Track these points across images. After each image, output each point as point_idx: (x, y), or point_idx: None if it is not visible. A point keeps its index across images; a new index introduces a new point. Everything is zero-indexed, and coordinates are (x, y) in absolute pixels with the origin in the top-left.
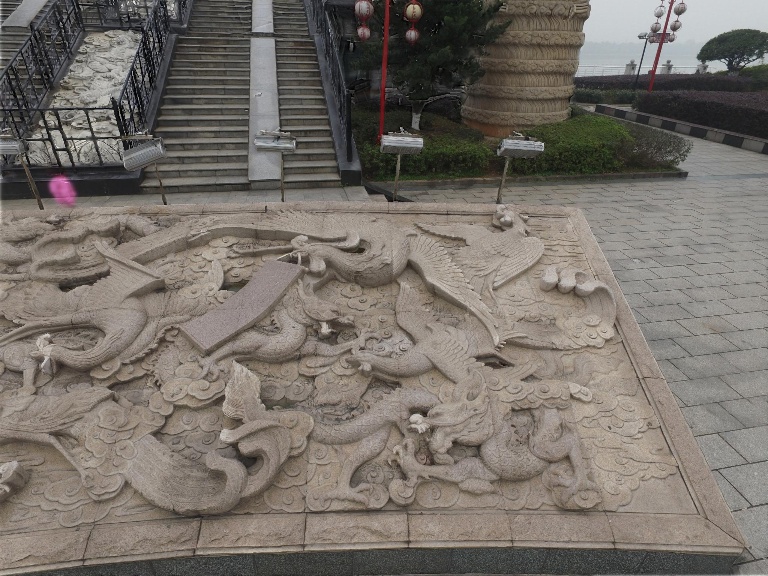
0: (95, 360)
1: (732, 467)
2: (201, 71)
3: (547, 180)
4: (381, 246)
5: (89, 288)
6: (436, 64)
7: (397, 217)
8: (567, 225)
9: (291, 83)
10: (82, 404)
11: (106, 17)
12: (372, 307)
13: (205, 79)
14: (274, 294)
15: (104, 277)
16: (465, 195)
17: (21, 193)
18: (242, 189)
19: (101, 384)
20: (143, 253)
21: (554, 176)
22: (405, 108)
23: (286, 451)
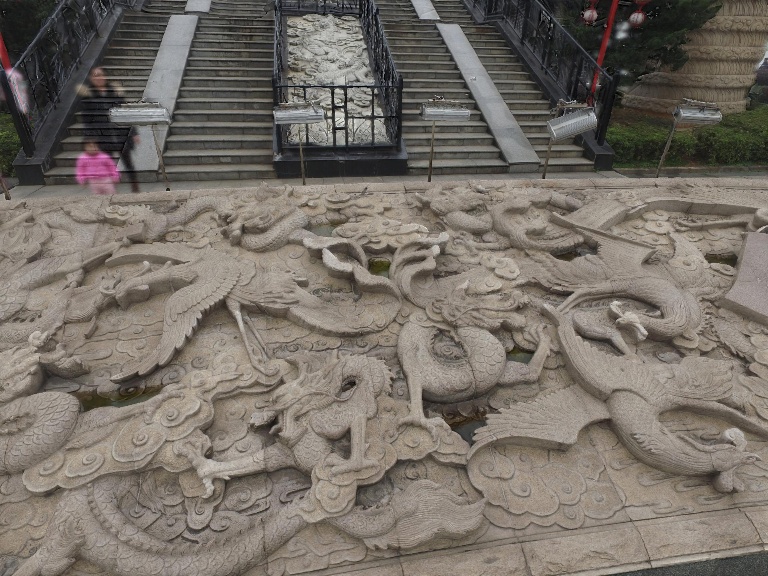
0: (683, 329)
1: None
2: (405, 55)
3: (750, 170)
4: None
5: (596, 257)
6: (653, 49)
7: None
8: None
9: (493, 68)
10: (720, 373)
11: (304, 1)
12: None
13: (413, 63)
14: None
15: (578, 248)
16: None
17: (297, 172)
18: (500, 172)
19: (692, 354)
20: (602, 224)
21: (756, 166)
22: None
23: None
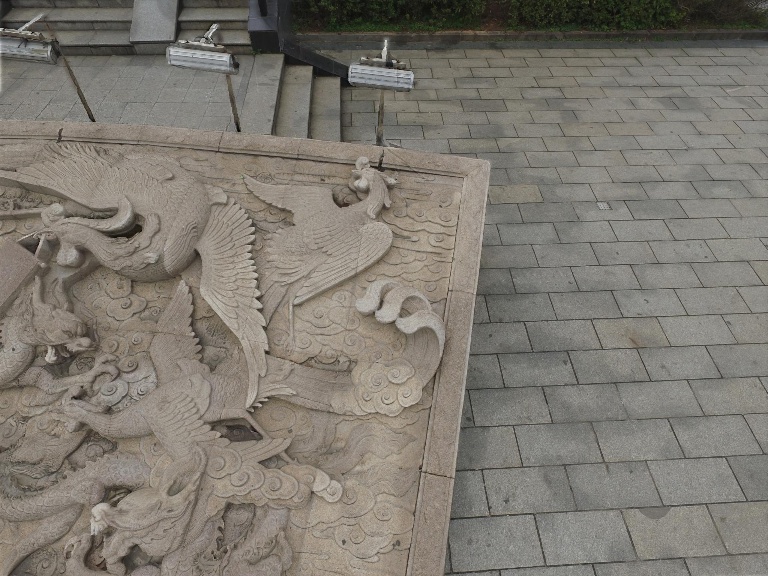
0: None
1: (521, 569)
2: None
3: (565, 38)
4: (152, 232)
5: None
6: None
7: (227, 160)
8: (456, 193)
9: None
10: None
11: None
12: (135, 316)
13: None
14: (2, 296)
15: None
16: (437, 62)
17: None
18: (125, 53)
19: None
20: None
21: (577, 32)
22: None
23: None
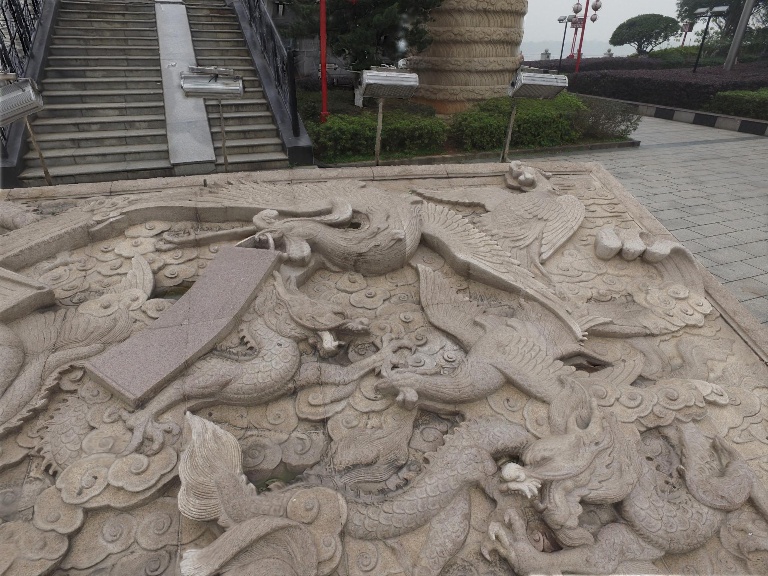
0: None
1: None
2: (94, 39)
3: (508, 155)
4: (385, 216)
5: None
6: (381, 27)
7: (386, 184)
8: (593, 182)
9: (211, 53)
10: None
11: None
12: (386, 302)
13: (100, 48)
14: (239, 296)
15: None
16: None
17: None
18: (163, 175)
19: None
20: (14, 253)
21: (514, 150)
22: (342, 88)
23: (311, 573)
